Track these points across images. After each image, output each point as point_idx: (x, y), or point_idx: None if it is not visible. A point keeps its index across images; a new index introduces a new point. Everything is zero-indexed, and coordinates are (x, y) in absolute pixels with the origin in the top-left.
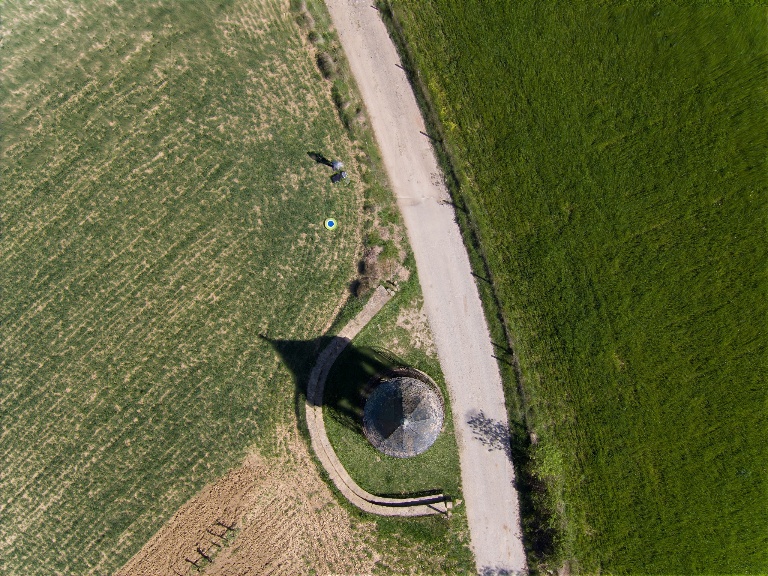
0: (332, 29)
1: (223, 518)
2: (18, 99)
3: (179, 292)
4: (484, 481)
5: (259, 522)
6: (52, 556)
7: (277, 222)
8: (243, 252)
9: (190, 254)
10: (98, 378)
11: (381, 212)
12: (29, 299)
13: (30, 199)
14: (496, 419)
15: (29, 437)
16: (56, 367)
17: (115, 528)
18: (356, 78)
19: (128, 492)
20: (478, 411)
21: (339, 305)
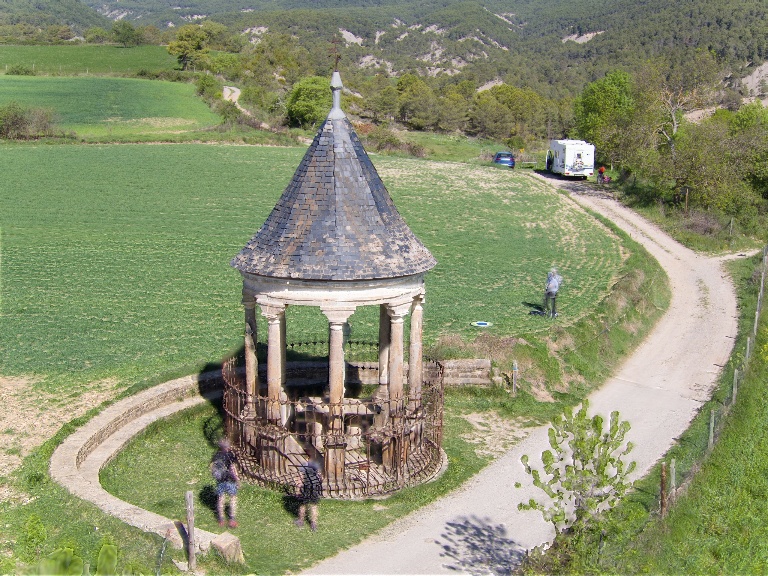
0: (660, 309)
1: None
2: None
3: None
4: None
5: None
6: None
7: None
8: None
9: None
10: (3, 295)
11: None
12: None
13: None
14: (523, 545)
15: None
16: None
17: None
18: (656, 328)
19: None
20: (493, 522)
21: None
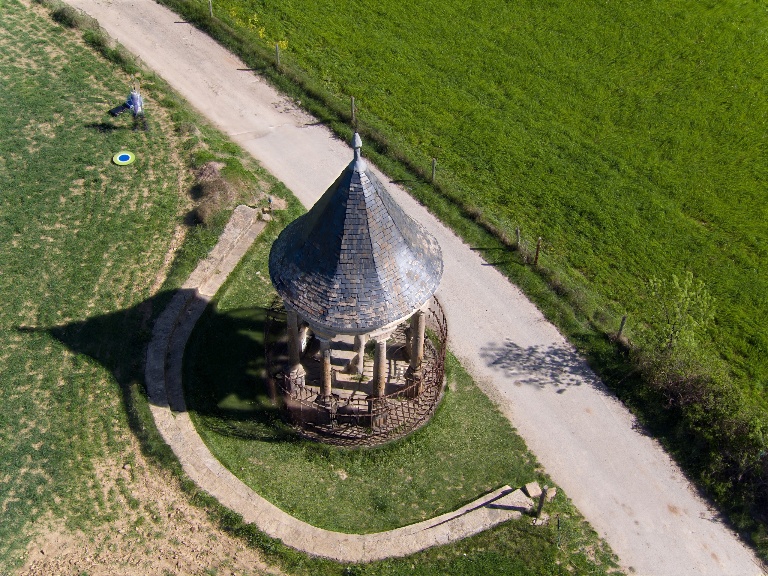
0: None
1: None
2: None
3: None
4: (579, 443)
5: None
6: None
7: (25, 177)
8: None
9: None
10: None
11: (207, 137)
12: None
13: None
14: (543, 344)
15: None
16: None
17: None
18: None
19: None
20: (502, 342)
21: (172, 248)
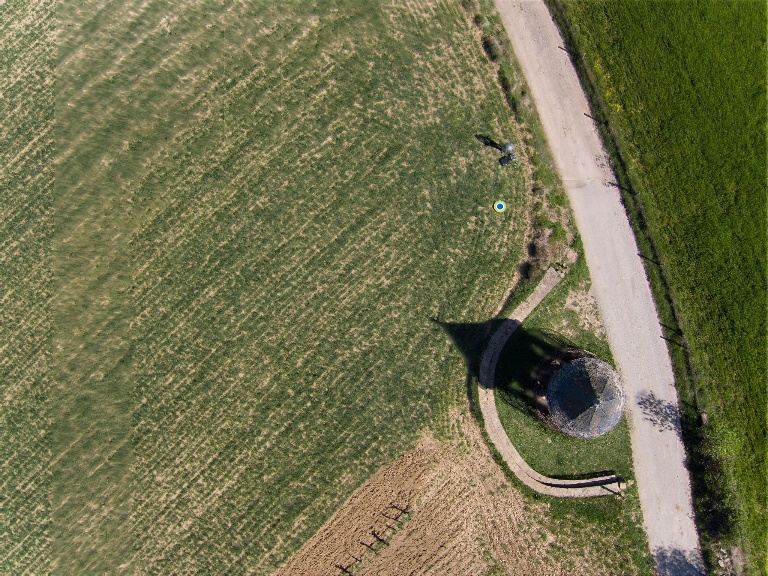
0: (495, 12)
1: (397, 501)
2: (186, 85)
3: (350, 276)
4: (655, 462)
5: (433, 505)
6: (228, 541)
7: (446, 205)
8: (413, 236)
9: (360, 238)
10: (271, 363)
11: (549, 194)
12: (201, 285)
13: (200, 185)
14: (666, 400)
15: (203, 422)
16: (229, 352)
17: (290, 512)
18: (519, 61)
19: (302, 476)
20: (648, 392)
21: (510, 287)
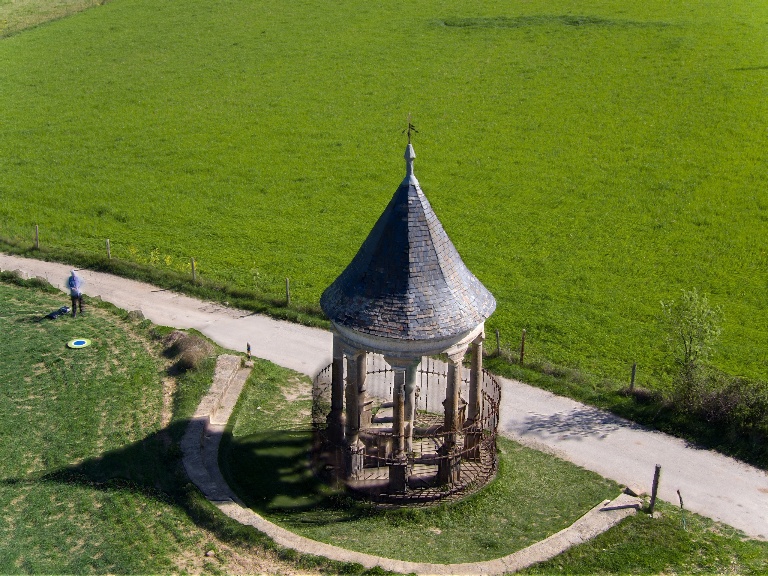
0: None
1: None
2: None
3: None
4: (647, 465)
5: None
6: None
7: None
8: None
9: None
10: None
11: None
12: None
13: None
14: (565, 410)
15: None
16: None
17: None
18: None
19: None
20: (527, 415)
21: (166, 393)
